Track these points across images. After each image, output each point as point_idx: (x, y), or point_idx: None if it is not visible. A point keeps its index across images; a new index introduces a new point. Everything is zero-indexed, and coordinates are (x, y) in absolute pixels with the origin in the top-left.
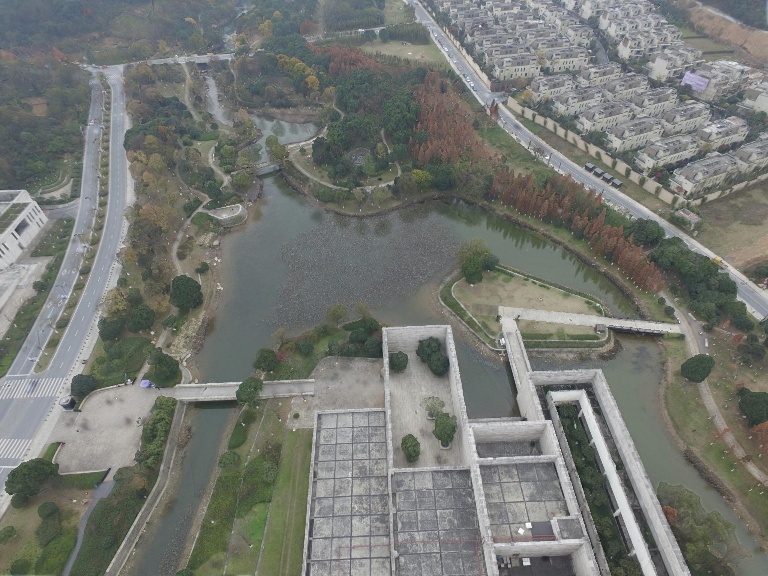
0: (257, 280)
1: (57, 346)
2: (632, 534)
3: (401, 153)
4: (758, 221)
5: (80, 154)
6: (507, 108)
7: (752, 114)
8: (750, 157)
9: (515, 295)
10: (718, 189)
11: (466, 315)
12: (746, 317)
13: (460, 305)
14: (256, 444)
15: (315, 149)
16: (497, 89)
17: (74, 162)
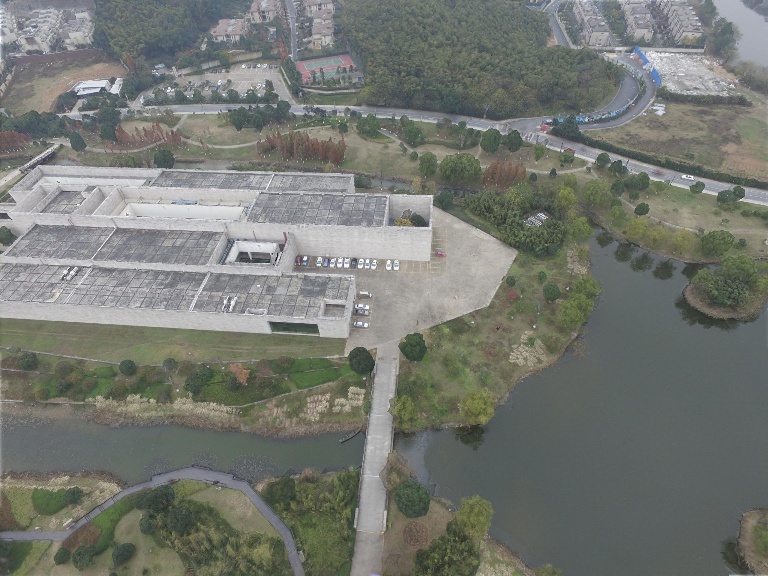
0: None
1: None
2: None
3: None
4: (32, 93)
5: None
6: None
7: None
8: None
9: None
10: None
11: None
12: (73, 119)
13: None
14: None
15: None
16: None
17: None
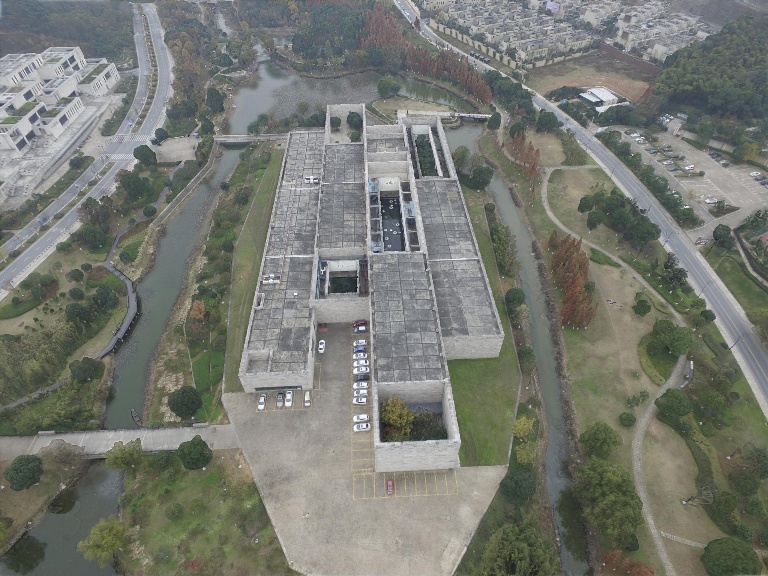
0: (256, 104)
1: (142, 124)
2: (437, 165)
3: (350, 44)
4: (562, 74)
5: (134, 48)
6: (429, 27)
7: (583, 24)
8: (565, 41)
9: (409, 105)
10: (544, 60)
11: (379, 113)
12: (531, 107)
13: (376, 110)
14: (258, 154)
15: (294, 42)
16: (424, 16)
17: (131, 51)
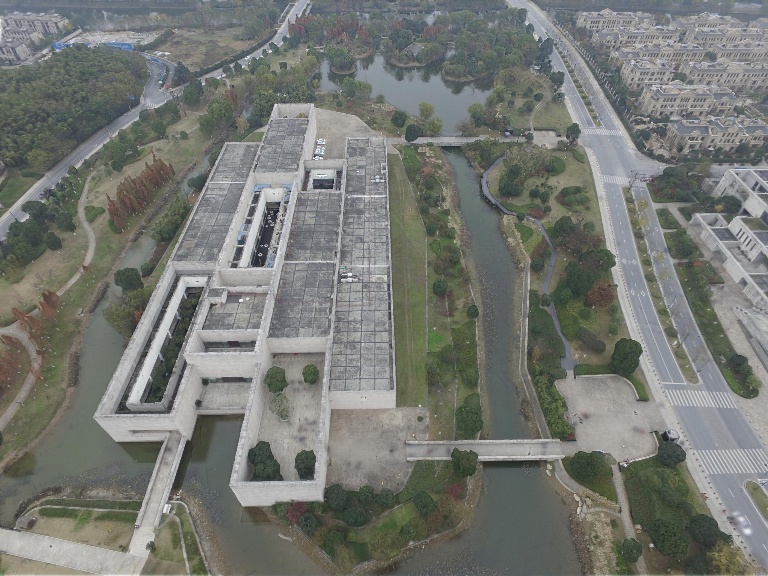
0: None
1: None
2: None
3: None
4: None
5: None
6: None
7: None
8: None
9: None
10: None
11: (193, 567)
12: None
13: None
14: (453, 396)
15: None
16: None
17: None
